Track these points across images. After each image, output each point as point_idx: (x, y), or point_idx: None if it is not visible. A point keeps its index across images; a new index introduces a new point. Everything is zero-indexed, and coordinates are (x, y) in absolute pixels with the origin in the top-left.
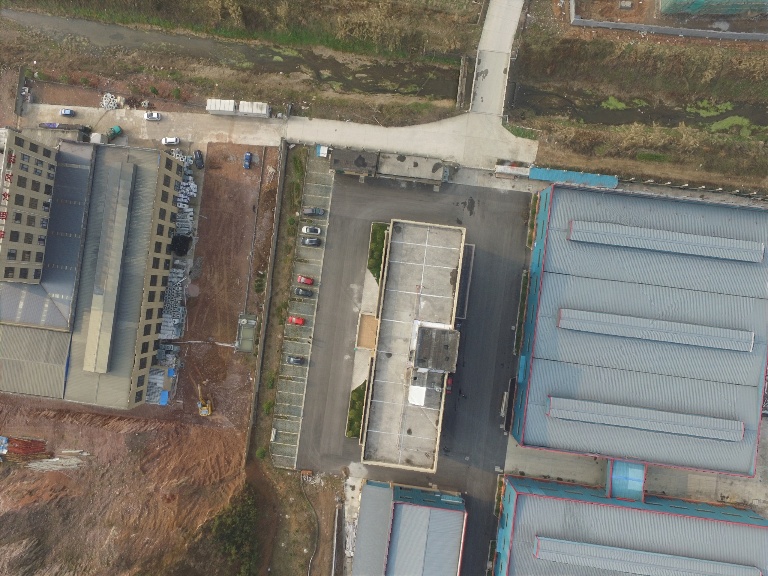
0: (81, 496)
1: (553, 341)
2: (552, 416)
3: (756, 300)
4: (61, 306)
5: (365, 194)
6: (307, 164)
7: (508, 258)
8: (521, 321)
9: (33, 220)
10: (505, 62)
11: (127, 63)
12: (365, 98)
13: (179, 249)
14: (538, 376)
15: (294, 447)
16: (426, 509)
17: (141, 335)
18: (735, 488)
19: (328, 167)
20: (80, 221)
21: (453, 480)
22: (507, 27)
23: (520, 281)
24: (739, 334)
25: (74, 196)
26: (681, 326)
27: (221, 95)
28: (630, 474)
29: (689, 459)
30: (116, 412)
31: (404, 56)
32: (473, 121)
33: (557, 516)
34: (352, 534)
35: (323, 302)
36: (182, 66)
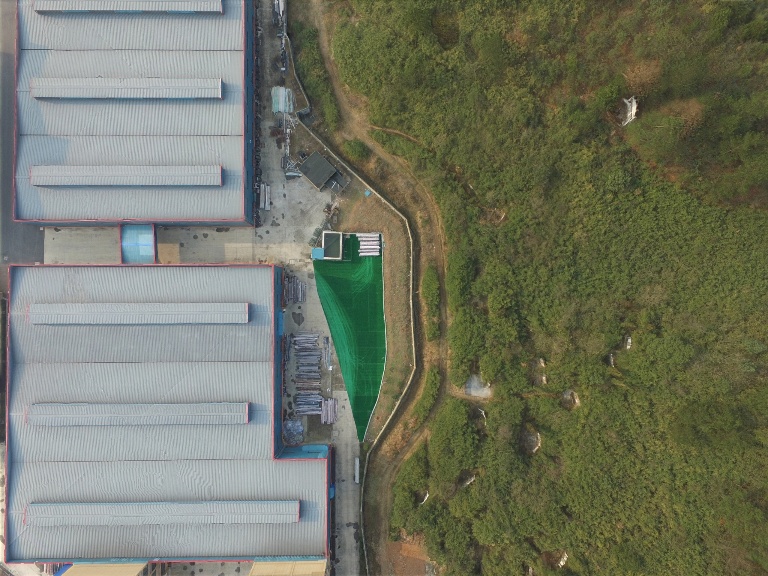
0: None
1: (42, 117)
2: (34, 184)
3: (232, 53)
4: None
5: None
6: None
7: None
8: None
9: None
10: None
11: None
12: None
13: None
14: (27, 151)
15: None
16: None
17: None
18: (271, 251)
19: None
20: None
21: None
22: None
23: None
24: (207, 82)
25: None
26: (150, 81)
27: None
28: (140, 240)
29: (185, 213)
30: None
31: None
32: None
33: (56, 284)
34: None
35: None
36: None
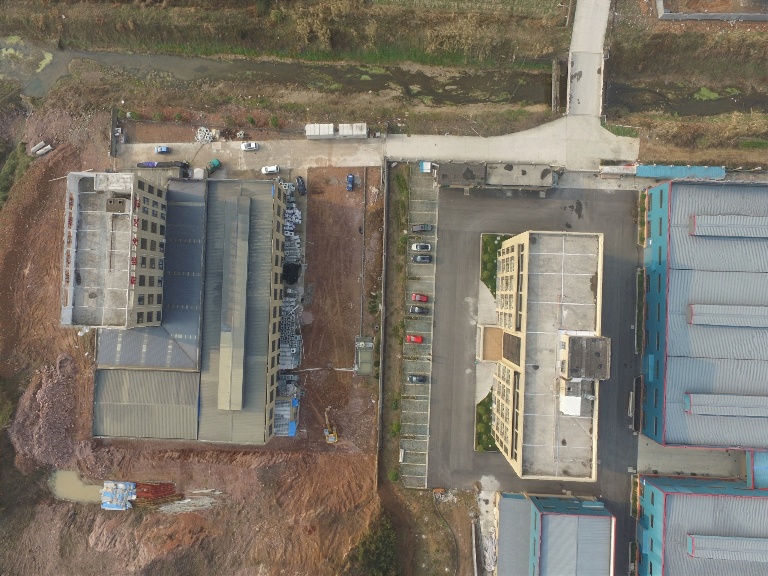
0: (221, 536)
1: (683, 337)
2: (693, 413)
3: None
4: (185, 346)
5: (471, 206)
6: (410, 181)
7: (621, 258)
8: (640, 320)
9: (153, 262)
10: (598, 62)
11: (214, 95)
12: (457, 110)
13: (291, 278)
14: (673, 374)
15: (423, 466)
16: (573, 517)
17: (269, 368)
18: None
19: (431, 182)
20: (197, 259)
21: (587, 485)
22: (597, 27)
23: (635, 280)
24: None
25: (188, 234)
26: None
27: (316, 119)
28: None
29: None
30: (240, 447)
31: (493, 64)
32: (572, 124)
33: (706, 512)
34: (492, 548)
35: (439, 318)
36: (270, 93)
